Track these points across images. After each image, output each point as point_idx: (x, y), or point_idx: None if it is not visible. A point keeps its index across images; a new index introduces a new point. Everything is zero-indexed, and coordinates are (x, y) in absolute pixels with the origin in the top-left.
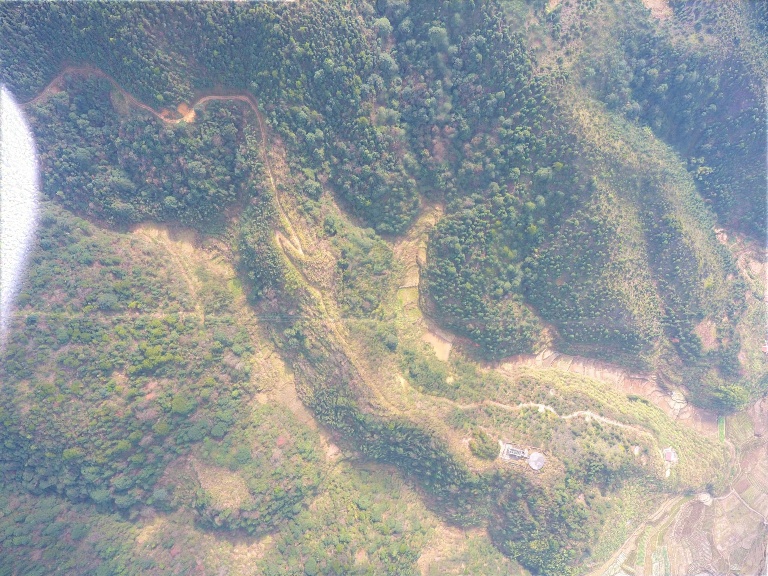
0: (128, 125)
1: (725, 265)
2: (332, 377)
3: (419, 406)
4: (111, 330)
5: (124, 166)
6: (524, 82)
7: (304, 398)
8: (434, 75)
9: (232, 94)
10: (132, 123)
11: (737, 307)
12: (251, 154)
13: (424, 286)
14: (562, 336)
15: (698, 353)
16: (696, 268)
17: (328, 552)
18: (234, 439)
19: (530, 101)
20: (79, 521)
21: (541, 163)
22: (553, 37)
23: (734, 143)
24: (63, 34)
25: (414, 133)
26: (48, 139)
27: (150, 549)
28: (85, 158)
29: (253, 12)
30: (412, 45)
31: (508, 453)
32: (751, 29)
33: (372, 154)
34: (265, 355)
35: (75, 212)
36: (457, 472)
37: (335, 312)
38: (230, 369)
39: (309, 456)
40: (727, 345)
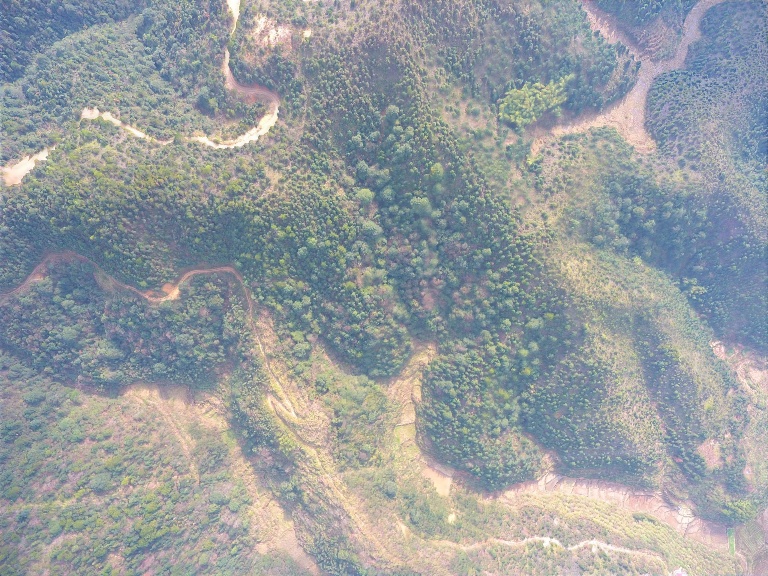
0: (113, 305)
1: (724, 383)
2: (332, 528)
3: (422, 555)
4: (105, 512)
5: (111, 338)
6: (510, 241)
7: (305, 546)
8: (419, 236)
9: (216, 267)
10: (117, 302)
11: (739, 423)
12: (238, 323)
13: (421, 425)
14: (563, 462)
15: (703, 473)
16: (695, 393)
17: None
18: None
19: (517, 259)
20: None
21: (532, 314)
22: (536, 189)
23: (726, 265)
24: (43, 231)
25: (402, 286)
26: (33, 323)
27: None
28: (71, 338)
29: (232, 205)
30: (395, 211)
31: None
32: (735, 161)
33: (360, 314)
34: (263, 504)
35: (64, 382)
36: None
37: (331, 467)
38: (228, 527)
39: None
40: (732, 462)
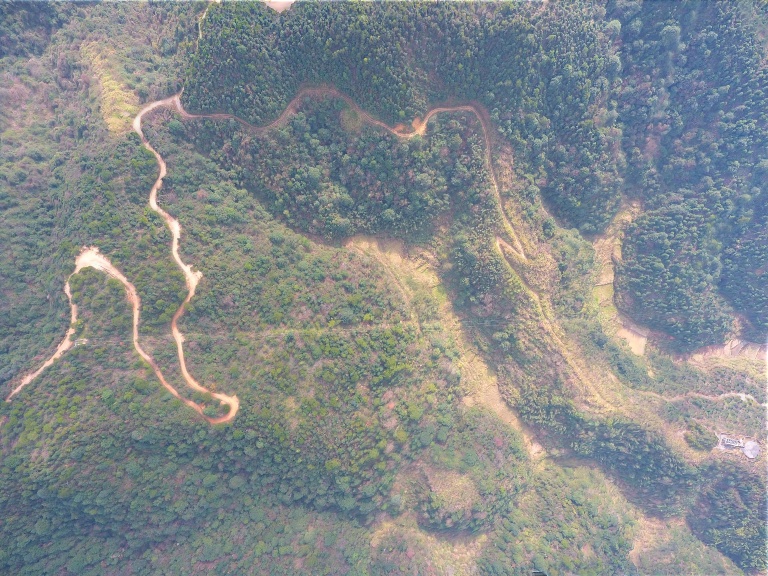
0: (360, 142)
1: None
2: (543, 377)
3: (632, 401)
4: (352, 343)
5: (346, 182)
6: (752, 75)
7: (509, 399)
8: (658, 74)
9: (459, 105)
10: (364, 140)
11: None
12: (476, 163)
13: (622, 283)
14: (753, 325)
15: None
16: None
17: (552, 548)
18: (456, 442)
19: (757, 94)
20: (326, 529)
21: (762, 155)
22: None
23: None
24: (312, 57)
25: (627, 132)
26: (284, 160)
27: (388, 553)
28: (317, 177)
29: (506, 24)
30: (639, 45)
31: (724, 443)
32: None
33: (593, 156)
34: (469, 359)
35: (294, 229)
36: (673, 464)
37: (551, 313)
38: (445, 374)
39: (521, 455)
40: None
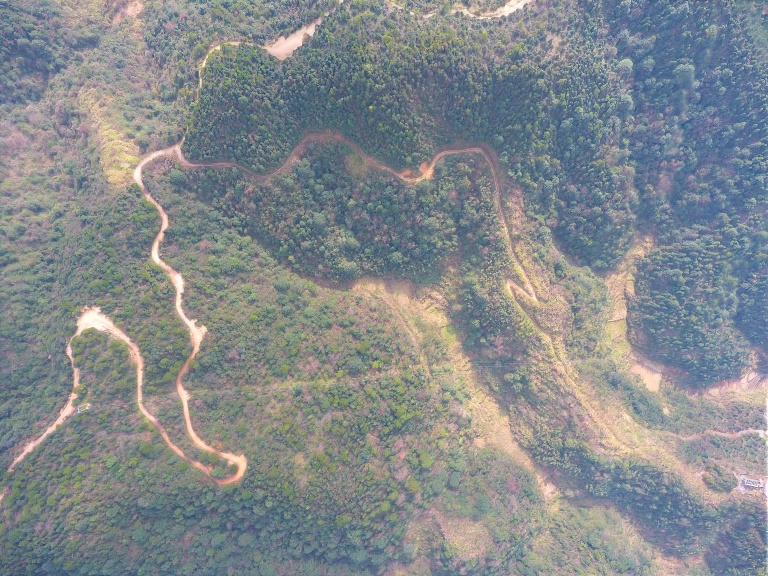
0: (366, 187)
1: None
2: (556, 418)
3: (649, 442)
4: (361, 392)
5: (352, 226)
6: None
7: (522, 440)
8: (671, 111)
9: (466, 147)
10: (370, 185)
11: None
12: (485, 205)
13: (636, 319)
14: None
15: None
16: None
17: None
18: (468, 488)
19: None
20: None
21: None
22: None
23: None
24: (315, 105)
25: (640, 169)
26: (288, 207)
27: None
28: (323, 223)
29: (515, 69)
30: (652, 83)
31: (743, 484)
32: None
33: (605, 195)
34: (480, 399)
35: (300, 274)
36: (691, 506)
37: (564, 355)
38: (456, 418)
39: (535, 498)
40: None
